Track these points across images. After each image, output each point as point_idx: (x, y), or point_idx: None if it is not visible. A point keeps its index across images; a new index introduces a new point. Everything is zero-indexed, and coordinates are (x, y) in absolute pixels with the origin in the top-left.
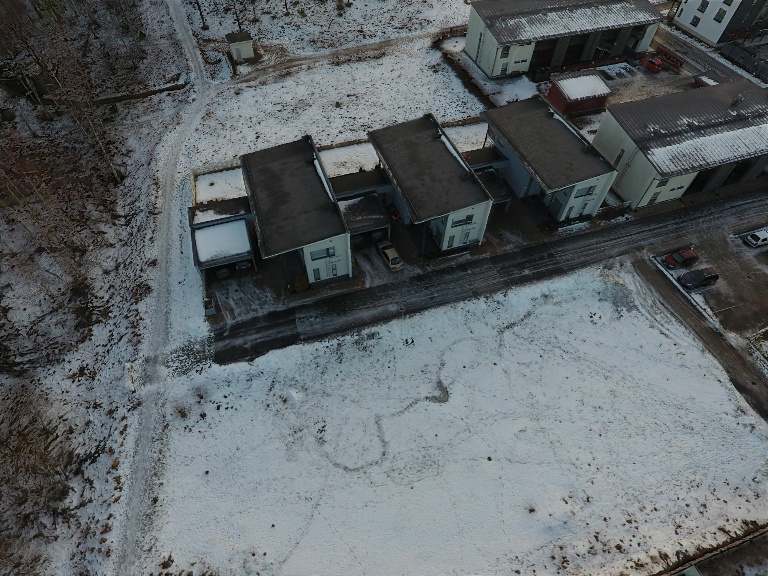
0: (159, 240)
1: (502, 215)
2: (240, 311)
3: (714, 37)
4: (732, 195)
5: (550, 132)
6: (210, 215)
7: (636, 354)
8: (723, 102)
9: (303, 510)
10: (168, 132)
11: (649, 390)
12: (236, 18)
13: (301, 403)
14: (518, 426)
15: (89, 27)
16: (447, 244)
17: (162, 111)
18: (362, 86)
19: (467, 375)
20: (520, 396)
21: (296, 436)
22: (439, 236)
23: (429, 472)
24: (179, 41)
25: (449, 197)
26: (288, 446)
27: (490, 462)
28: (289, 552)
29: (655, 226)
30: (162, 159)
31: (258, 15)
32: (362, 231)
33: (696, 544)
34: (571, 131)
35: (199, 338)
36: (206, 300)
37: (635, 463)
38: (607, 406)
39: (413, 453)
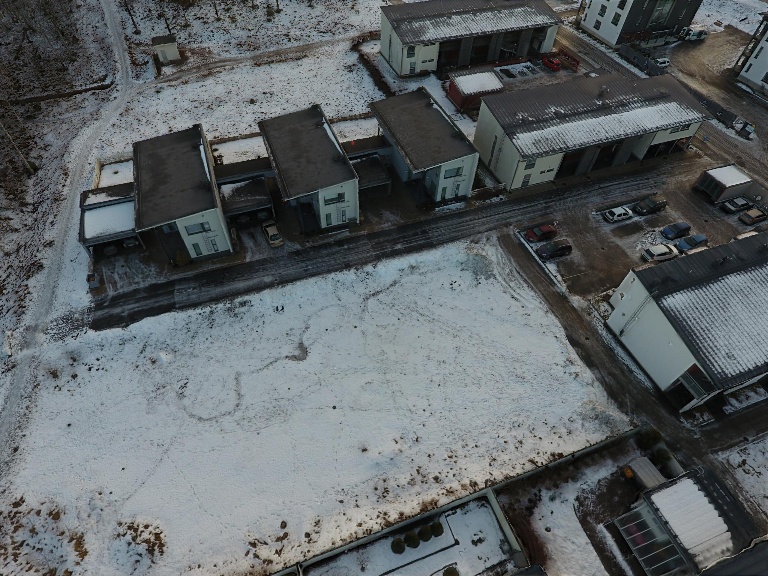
0: (59, 223)
1: (386, 197)
2: (123, 284)
3: (613, 39)
4: (602, 178)
5: (427, 120)
6: (102, 197)
7: (486, 316)
8: (591, 93)
9: (153, 455)
10: (85, 127)
11: (492, 346)
12: (168, 23)
13: (169, 364)
14: (366, 379)
15: (25, 32)
16: (326, 222)
17: (84, 109)
18: (278, 84)
19: (328, 336)
20: (372, 353)
21: (158, 392)
22: (319, 215)
23: (276, 420)
24: (111, 45)
25: (320, 176)
26: (149, 401)
27: (334, 410)
28: (134, 491)
29: (526, 205)
30: (75, 151)
31: (190, 20)
32: (245, 210)
33: (505, 473)
34: (446, 119)
35: (80, 308)
36: (90, 274)
37: (466, 408)
38: (450, 360)
39: (265, 404)
